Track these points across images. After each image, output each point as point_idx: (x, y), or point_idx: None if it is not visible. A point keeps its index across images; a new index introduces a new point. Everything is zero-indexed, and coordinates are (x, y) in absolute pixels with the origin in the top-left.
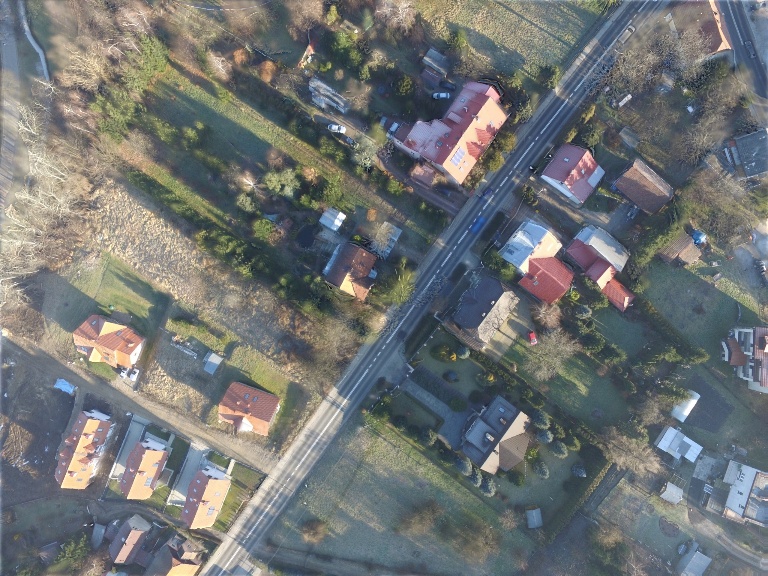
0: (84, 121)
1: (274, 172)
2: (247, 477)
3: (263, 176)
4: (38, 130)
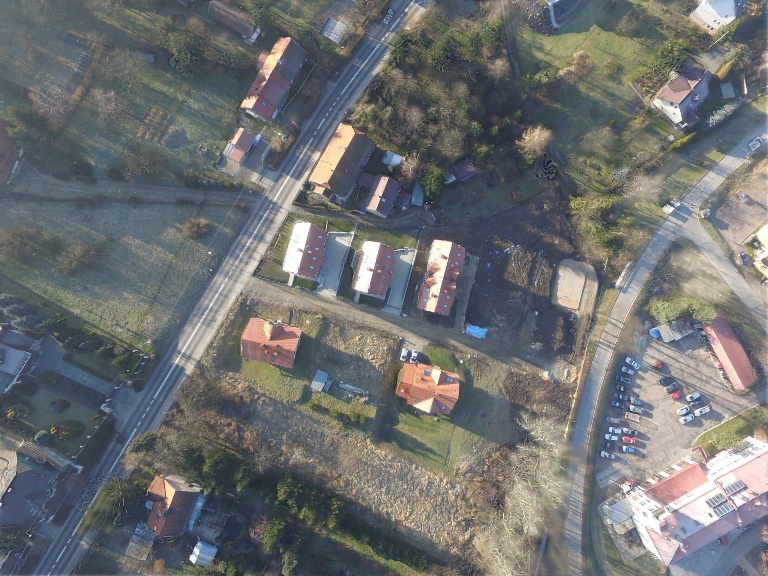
0: None
1: None
2: (274, 270)
3: None
4: None
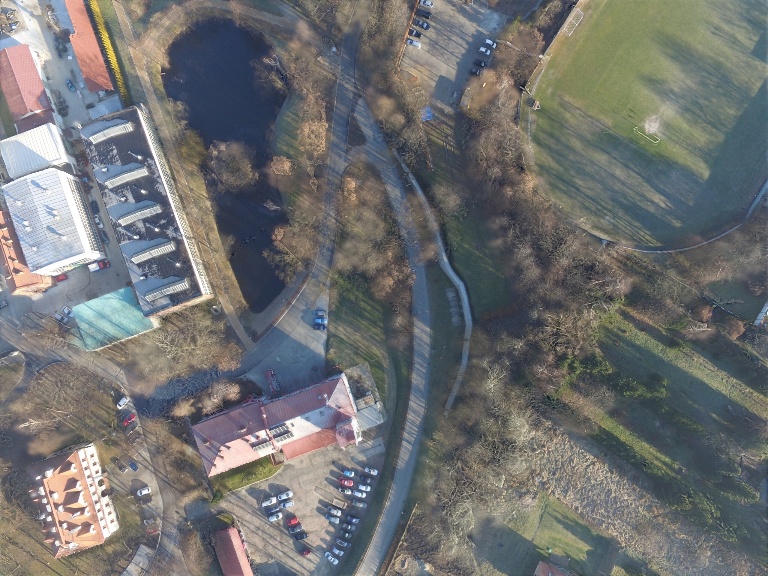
0: (551, 378)
1: (766, 443)
2: None
3: (754, 446)
4: (496, 382)
